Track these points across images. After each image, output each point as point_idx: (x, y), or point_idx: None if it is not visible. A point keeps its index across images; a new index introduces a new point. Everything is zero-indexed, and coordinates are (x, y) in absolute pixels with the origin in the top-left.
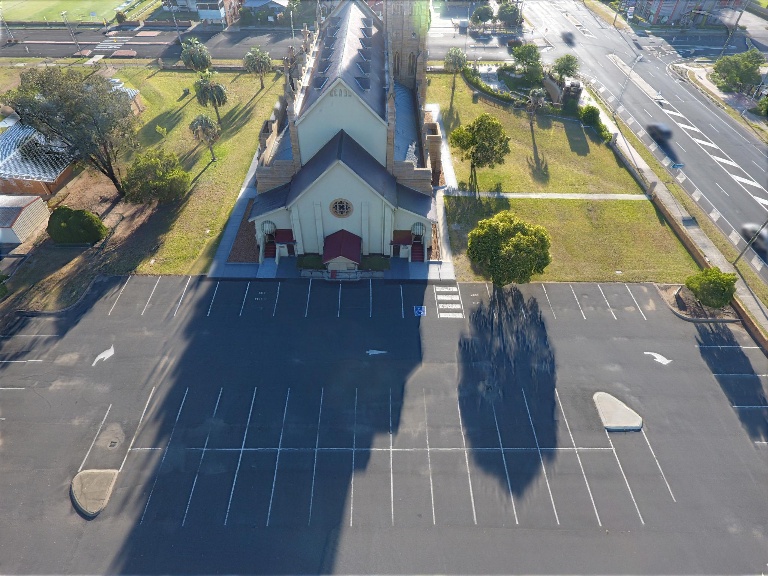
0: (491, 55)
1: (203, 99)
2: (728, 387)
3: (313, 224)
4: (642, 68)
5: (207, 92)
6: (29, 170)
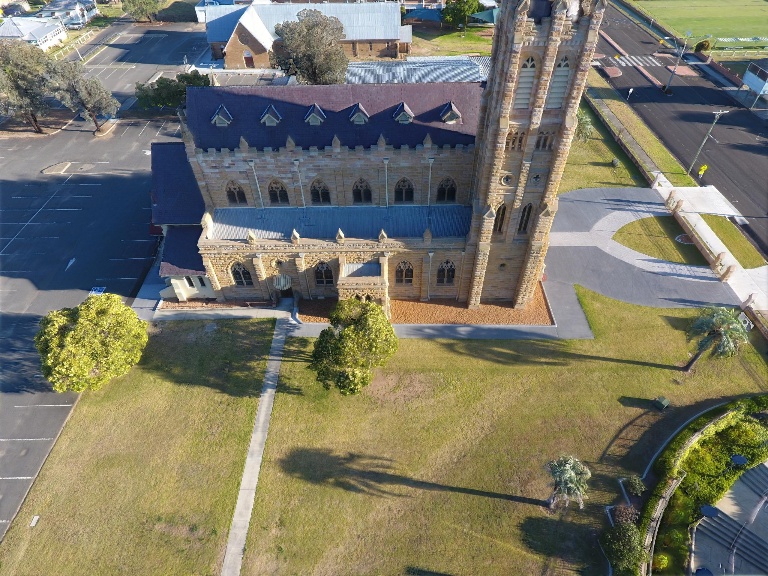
0: None
1: None
2: None
3: None
4: None
5: None
6: None
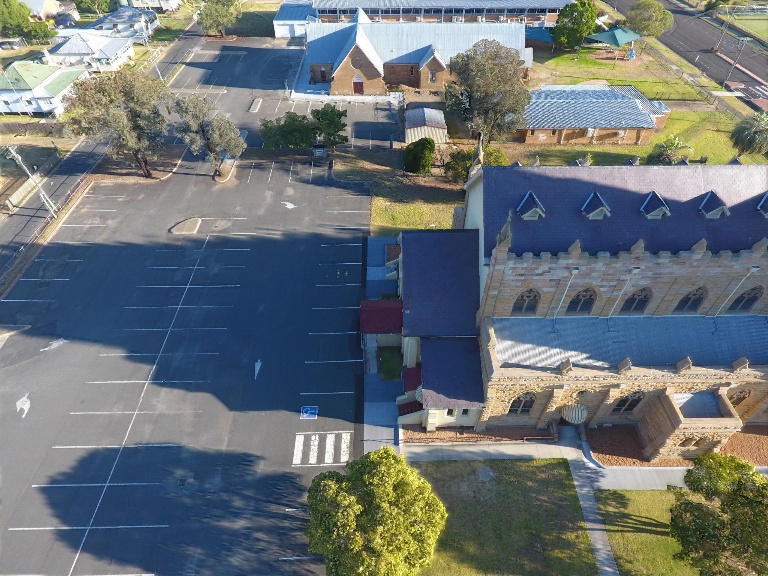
0: None
1: None
2: None
3: None
4: None
5: None
6: None
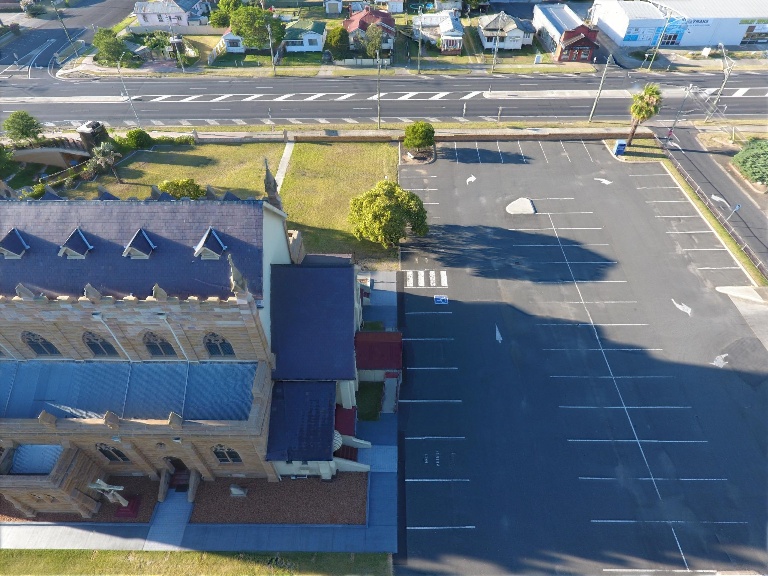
0: None
1: None
2: (489, 161)
3: None
4: (49, 91)
5: None
6: None
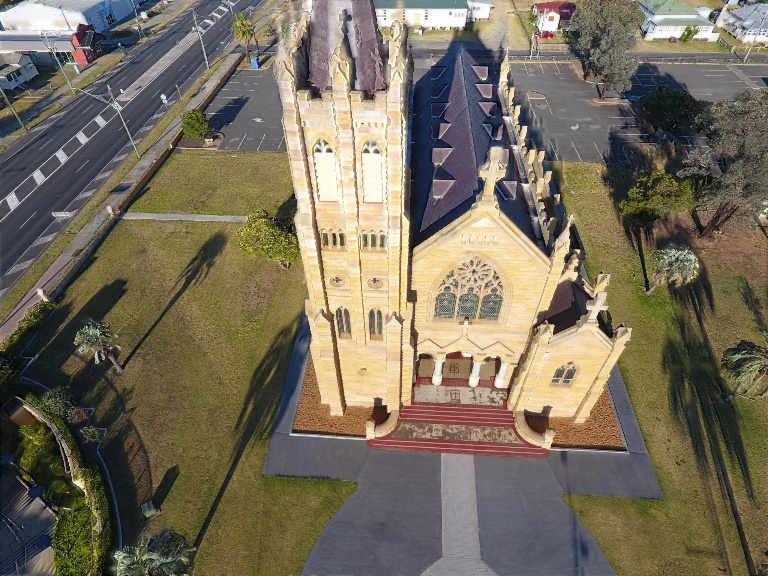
0: None
1: None
2: None
3: None
4: None
5: None
6: None
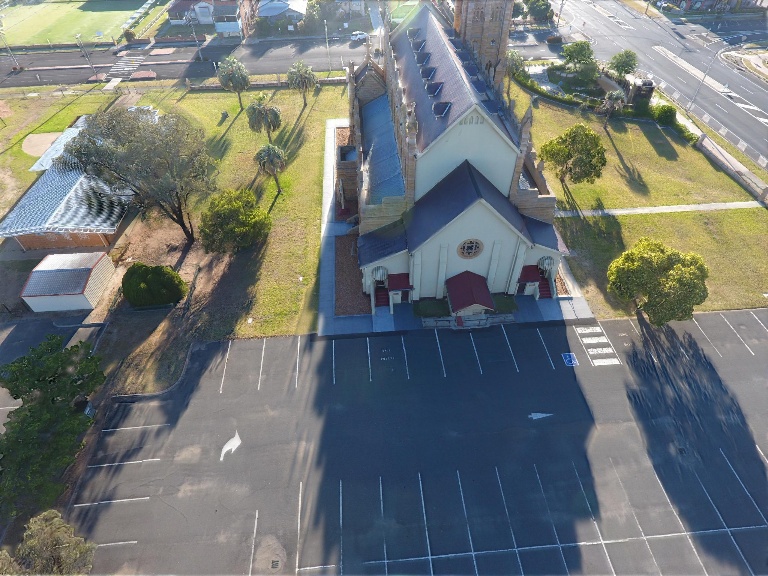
0: (533, 54)
1: (257, 124)
2: None
3: (435, 267)
4: (695, 59)
5: (261, 117)
6: (85, 221)
